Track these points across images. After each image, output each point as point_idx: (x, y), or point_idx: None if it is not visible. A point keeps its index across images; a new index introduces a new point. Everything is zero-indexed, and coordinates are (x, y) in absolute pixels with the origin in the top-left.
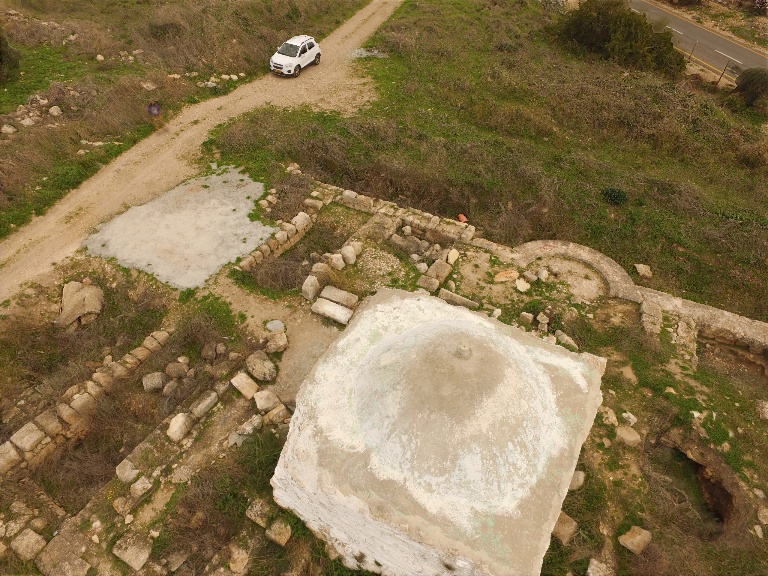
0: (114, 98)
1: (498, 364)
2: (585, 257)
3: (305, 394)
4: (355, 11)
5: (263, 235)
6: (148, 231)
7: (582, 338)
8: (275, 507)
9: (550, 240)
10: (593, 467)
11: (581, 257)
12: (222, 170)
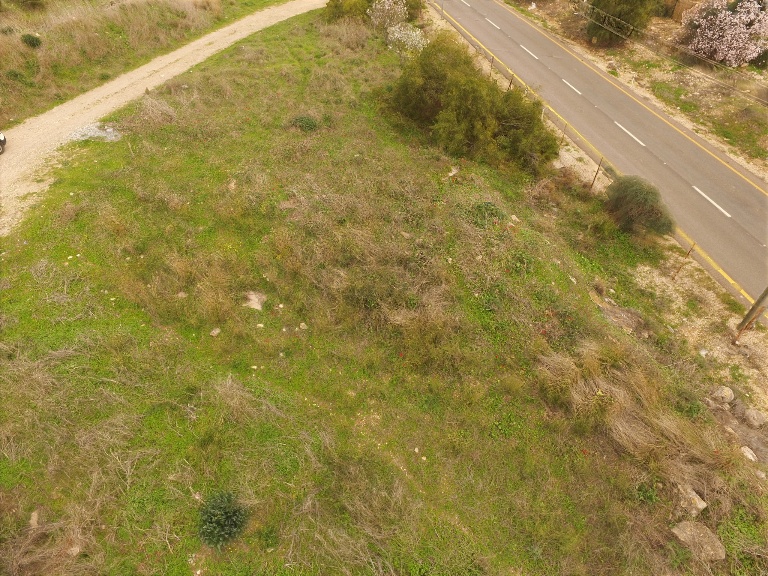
0: None
1: None
2: None
3: None
4: (152, 57)
5: None
6: None
7: None
8: None
9: None
10: None
11: None
12: None
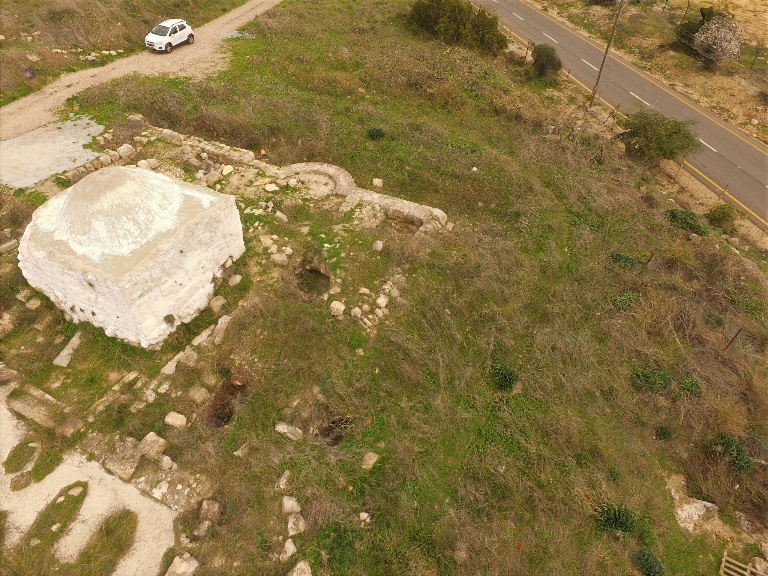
0: (0, 66)
1: (123, 178)
2: (330, 172)
3: (37, 212)
4: (246, 1)
5: (90, 157)
6: (4, 156)
7: (296, 216)
8: (33, 291)
9: (312, 162)
10: (250, 274)
11: (327, 172)
12: (76, 118)
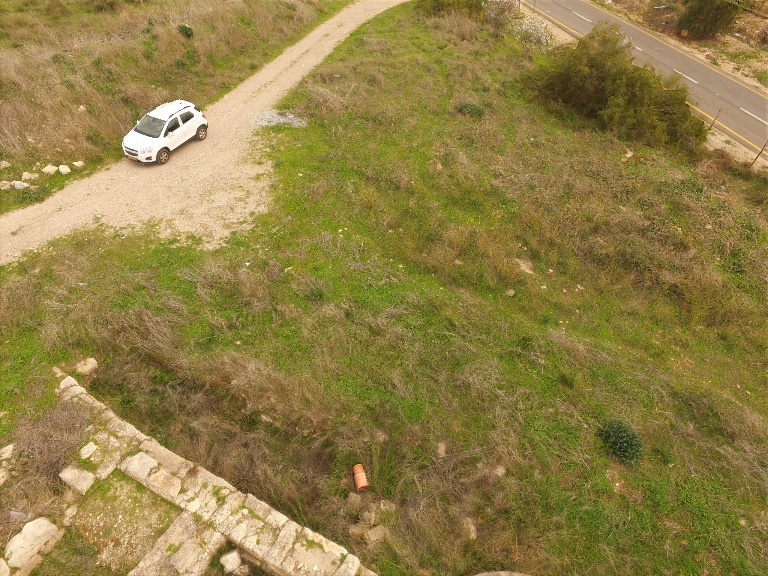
0: None
1: None
2: None
3: None
4: (283, 48)
5: None
6: None
7: None
8: None
9: (503, 573)
10: None
11: None
12: None
